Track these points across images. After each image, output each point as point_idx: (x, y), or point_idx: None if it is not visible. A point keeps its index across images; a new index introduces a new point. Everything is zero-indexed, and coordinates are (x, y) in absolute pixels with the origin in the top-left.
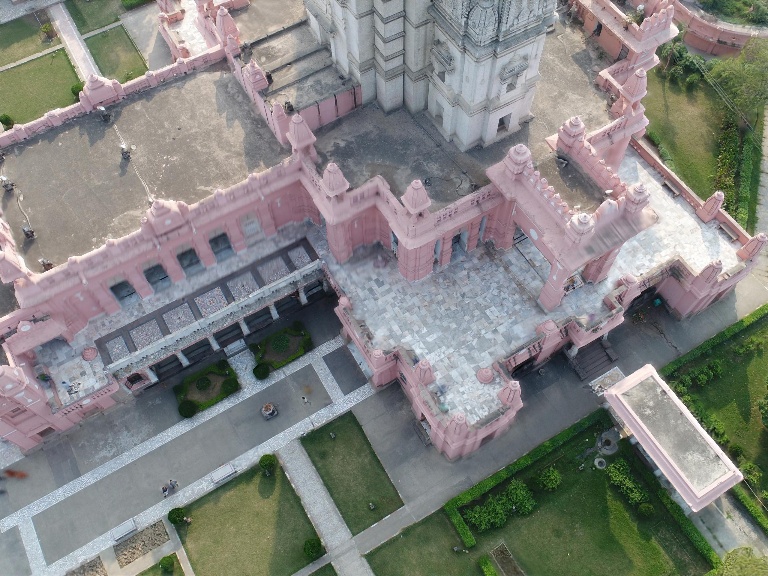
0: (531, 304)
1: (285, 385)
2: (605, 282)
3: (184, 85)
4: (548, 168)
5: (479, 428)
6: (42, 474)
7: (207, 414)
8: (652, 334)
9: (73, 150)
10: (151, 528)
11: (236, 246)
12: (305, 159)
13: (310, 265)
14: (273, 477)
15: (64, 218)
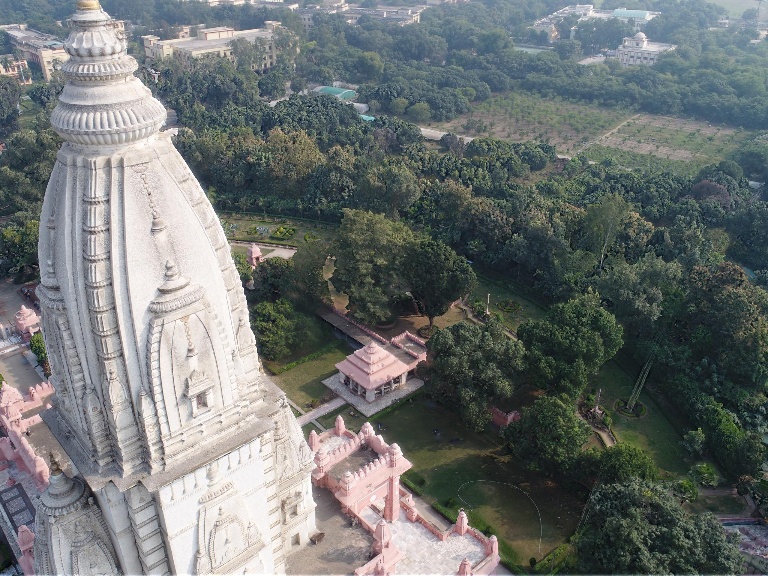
0: None
1: None
2: None
3: None
4: None
5: None
6: None
7: None
8: None
9: None
10: None
11: None
12: None
13: None
14: None
15: None
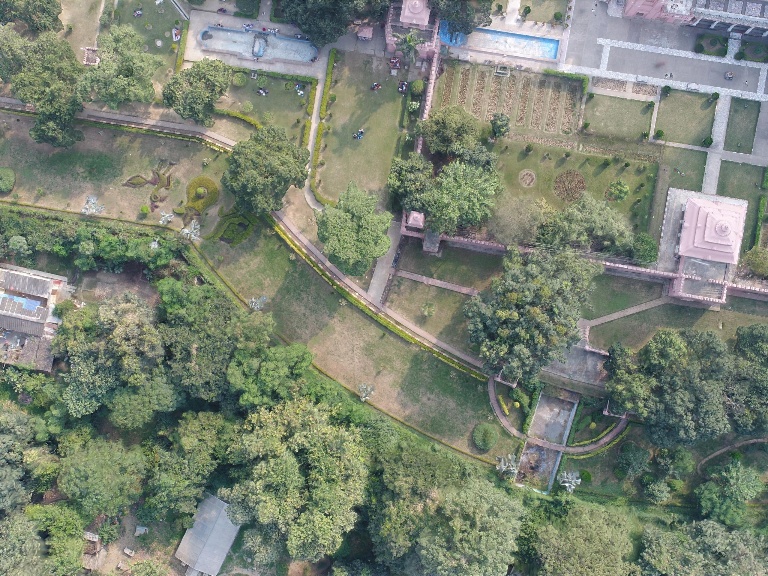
0: None
1: (743, 69)
2: None
3: None
4: None
5: None
6: (624, 31)
7: (703, 57)
8: None
9: None
10: (652, 86)
11: None
12: None
13: None
14: (711, 104)
15: None
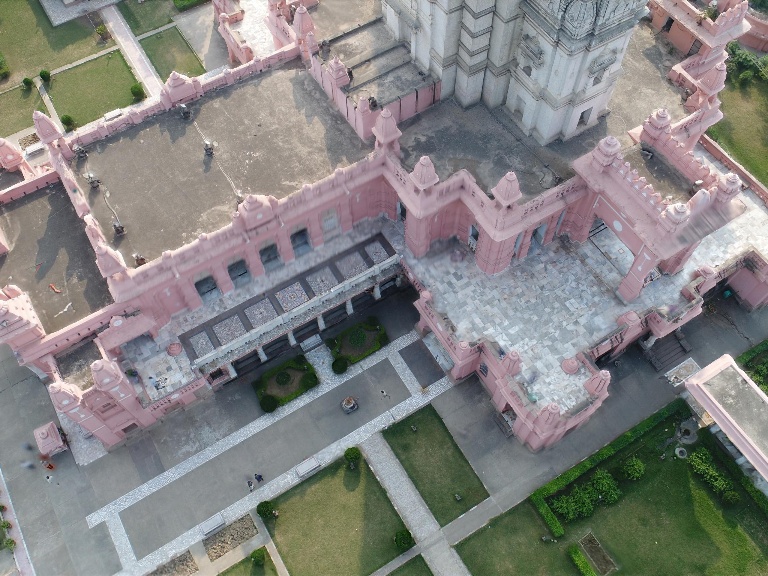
0: (610, 296)
1: (363, 379)
2: (681, 274)
3: (260, 83)
4: (634, 160)
5: (569, 418)
6: (126, 470)
7: (287, 409)
8: (723, 325)
9: (155, 147)
10: (239, 522)
11: (314, 241)
12: (389, 154)
13: (389, 259)
14: (357, 470)
15: (152, 214)
